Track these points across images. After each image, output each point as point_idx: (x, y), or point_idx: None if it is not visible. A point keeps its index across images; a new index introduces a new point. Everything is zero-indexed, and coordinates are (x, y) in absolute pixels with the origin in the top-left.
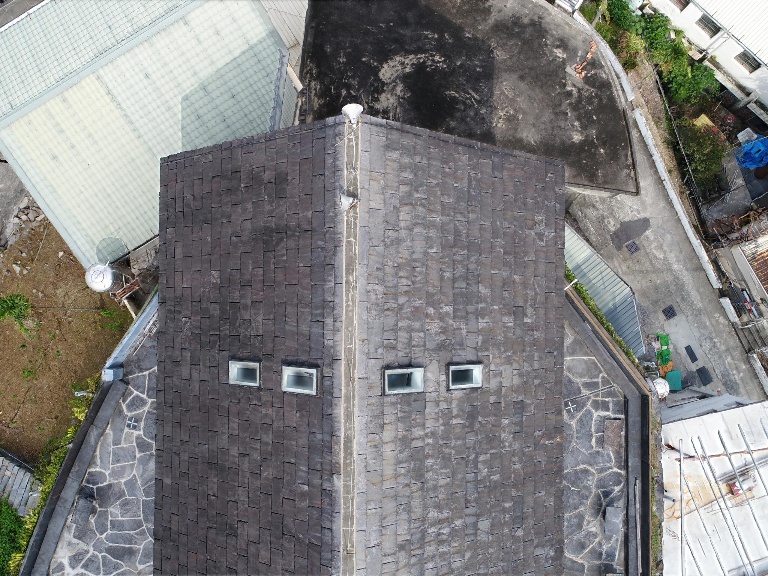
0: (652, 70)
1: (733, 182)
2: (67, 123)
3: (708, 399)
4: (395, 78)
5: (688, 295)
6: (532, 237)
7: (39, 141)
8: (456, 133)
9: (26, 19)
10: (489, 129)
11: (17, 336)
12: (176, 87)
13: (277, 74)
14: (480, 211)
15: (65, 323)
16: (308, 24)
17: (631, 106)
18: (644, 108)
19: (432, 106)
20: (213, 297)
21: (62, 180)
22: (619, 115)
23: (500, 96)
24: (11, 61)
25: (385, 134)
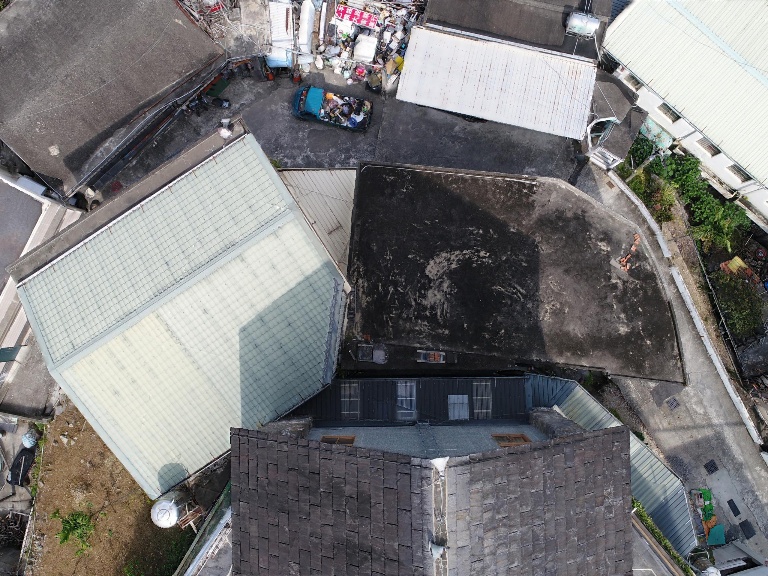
0: (684, 211)
1: (767, 323)
2: (128, 360)
3: (756, 570)
4: (441, 274)
5: (729, 449)
6: (602, 513)
7: (101, 378)
8: (503, 328)
9: (82, 249)
10: (536, 323)
11: (66, 506)
12: (234, 320)
13: (332, 301)
14: (555, 508)
15: (114, 494)
16: (354, 223)
17: (668, 262)
18: (679, 257)
19: (479, 301)
20: None
21: (124, 413)
22: (664, 306)
23: (546, 290)
24: (70, 295)
25: (469, 470)
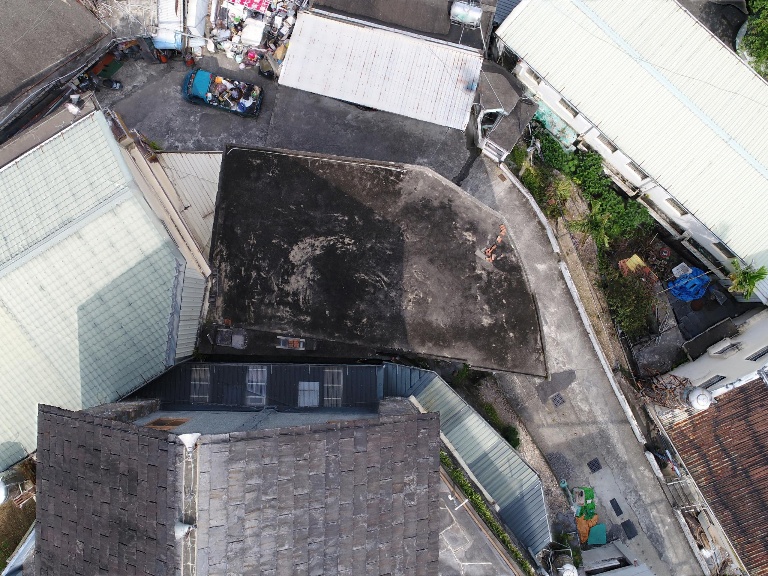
0: (585, 208)
1: (665, 323)
2: None
3: (625, 569)
4: (305, 260)
5: (613, 448)
6: (401, 500)
7: None
8: (366, 316)
9: None
10: (399, 312)
11: None
12: (72, 298)
13: (174, 282)
14: (340, 492)
15: None
16: (218, 206)
17: (557, 257)
18: (573, 253)
19: (342, 289)
20: (78, 568)
21: None
22: (529, 299)
23: (410, 279)
24: None
25: (228, 448)
